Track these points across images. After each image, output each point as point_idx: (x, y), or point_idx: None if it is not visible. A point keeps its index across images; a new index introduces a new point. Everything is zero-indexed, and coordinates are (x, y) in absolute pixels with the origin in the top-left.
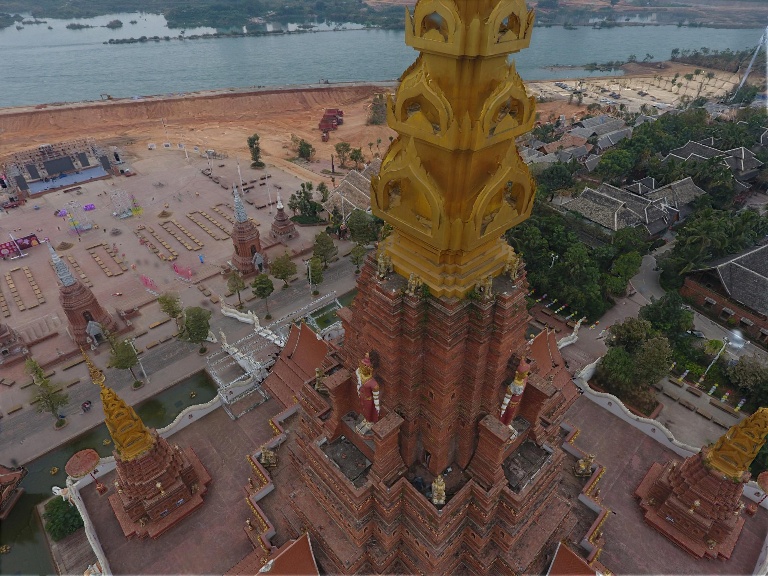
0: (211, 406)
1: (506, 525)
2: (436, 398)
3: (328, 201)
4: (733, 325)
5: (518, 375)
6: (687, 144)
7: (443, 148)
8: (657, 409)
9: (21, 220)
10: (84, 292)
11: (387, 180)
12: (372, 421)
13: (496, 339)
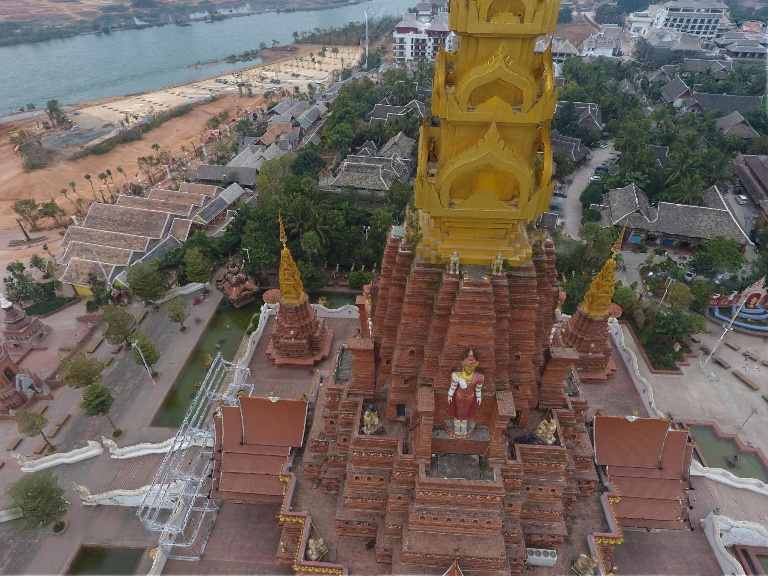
0: (157, 569)
1: (576, 427)
2: (523, 357)
3: (66, 273)
4: None
5: (559, 304)
6: (375, 107)
7: (526, 124)
8: None
9: None
10: None
11: (457, 174)
12: (466, 417)
13: (550, 281)
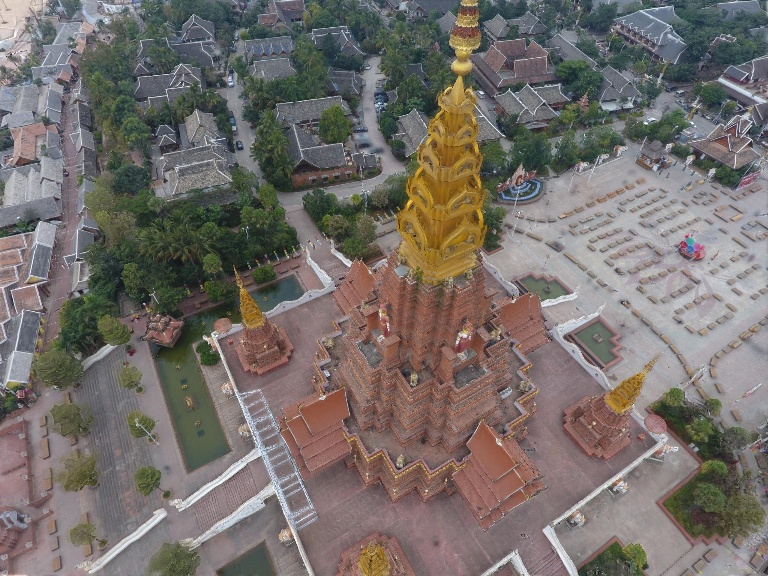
0: None
1: None
2: None
3: None
4: (333, 181)
5: None
6: (139, 81)
7: None
8: (380, 249)
9: None
10: None
11: None
12: None
13: None
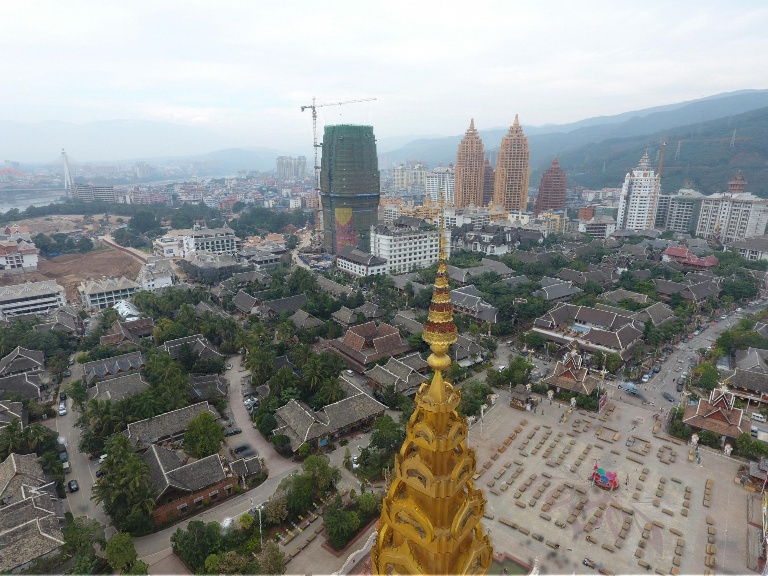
0: None
1: None
2: None
3: None
4: (209, 503)
5: None
6: None
7: None
8: None
9: None
10: None
11: None
12: None
13: None
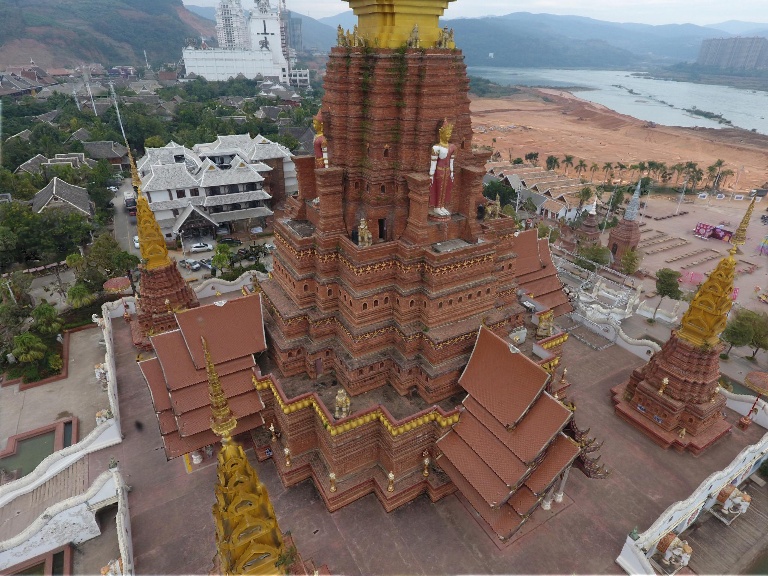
0: None
1: None
2: None
3: None
4: None
5: None
6: None
7: None
8: None
9: (759, 231)
10: (629, 231)
11: None
12: None
13: None
